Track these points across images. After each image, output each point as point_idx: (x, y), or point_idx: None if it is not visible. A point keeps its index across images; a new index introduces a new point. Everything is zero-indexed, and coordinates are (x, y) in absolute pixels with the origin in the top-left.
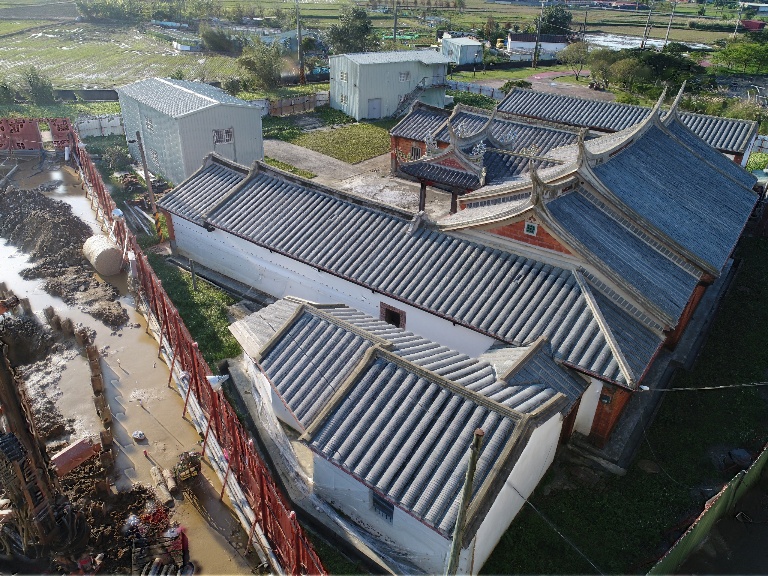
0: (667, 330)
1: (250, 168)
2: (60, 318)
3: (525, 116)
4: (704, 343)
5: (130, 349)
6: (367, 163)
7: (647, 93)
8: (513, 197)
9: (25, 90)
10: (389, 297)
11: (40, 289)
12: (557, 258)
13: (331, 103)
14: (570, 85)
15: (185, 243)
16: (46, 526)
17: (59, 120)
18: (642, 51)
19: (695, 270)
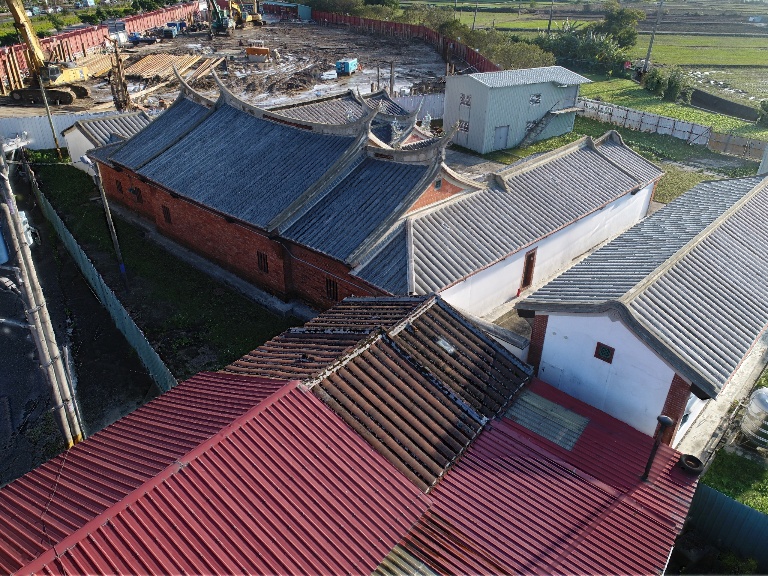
0: None
1: None
2: None
3: None
4: None
5: None
6: None
7: None
8: None
9: None
10: None
11: None
12: None
13: None
14: None
15: None
16: (115, 100)
17: None
18: None
19: None
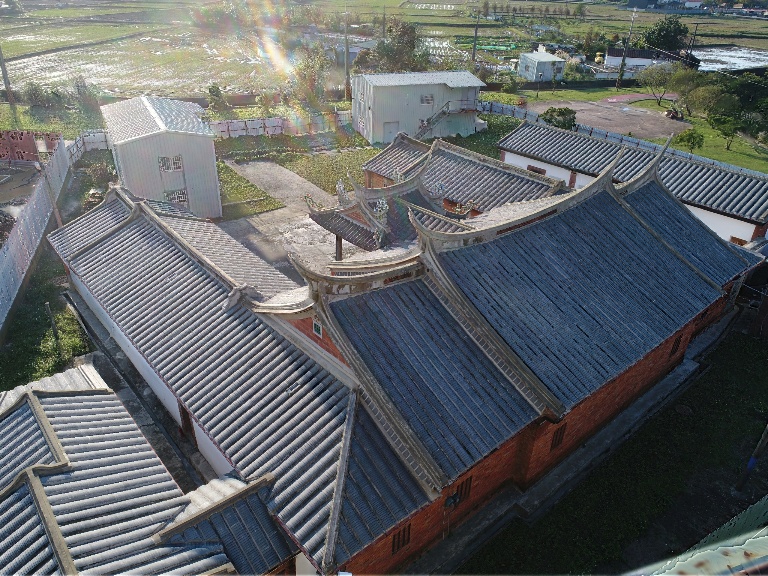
0: None
1: None
2: None
3: (526, 155)
4: (576, 485)
5: None
6: (349, 195)
7: (720, 128)
8: None
9: (75, 97)
10: None
11: None
12: (341, 369)
13: (353, 123)
14: (645, 111)
15: (75, 279)
16: None
17: (53, 134)
18: (728, 77)
19: (538, 401)
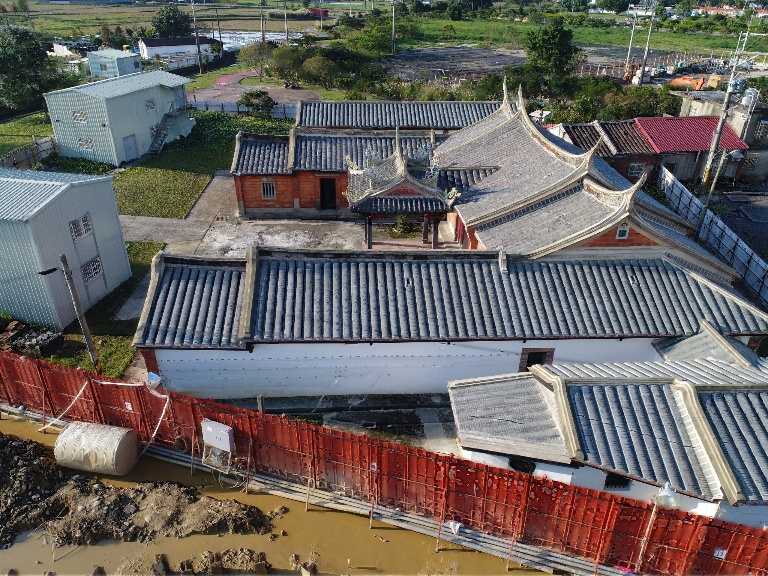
0: (733, 280)
1: (247, 257)
2: (169, 564)
3: None
4: None
5: (325, 541)
6: (198, 213)
7: (356, 86)
8: (526, 209)
9: None
10: (548, 340)
11: (57, 547)
12: (646, 252)
13: (61, 151)
14: (264, 87)
15: (184, 381)
16: None
17: None
18: (327, 48)
19: (681, 229)
